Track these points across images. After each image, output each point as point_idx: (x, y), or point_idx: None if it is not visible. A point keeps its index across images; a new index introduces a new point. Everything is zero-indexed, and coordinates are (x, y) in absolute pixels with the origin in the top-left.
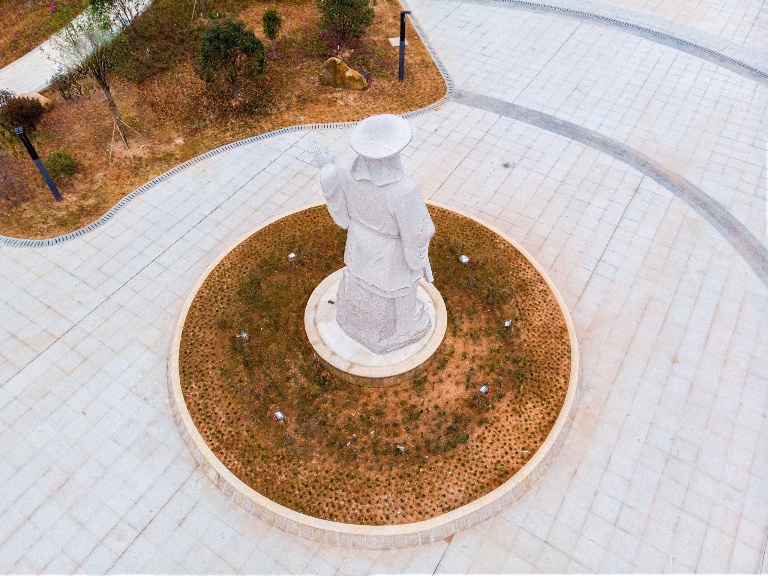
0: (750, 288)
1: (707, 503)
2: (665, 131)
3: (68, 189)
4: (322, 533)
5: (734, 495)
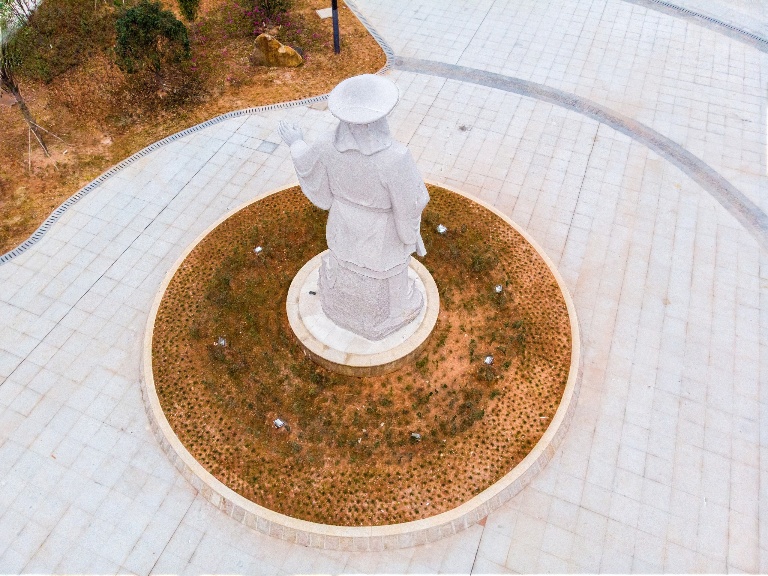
0: (721, 221)
1: (726, 439)
2: (610, 77)
3: None
4: (350, 541)
5: (749, 426)
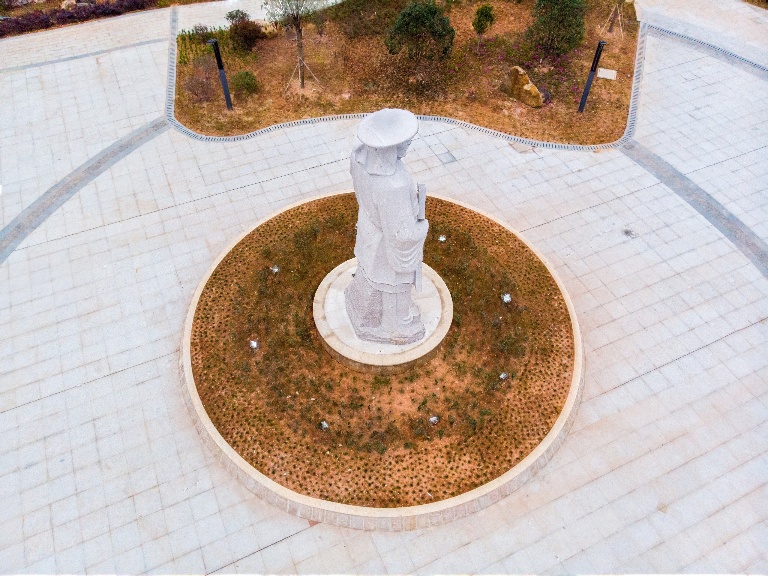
0: None
1: None
2: None
3: (242, 103)
4: (220, 452)
5: None
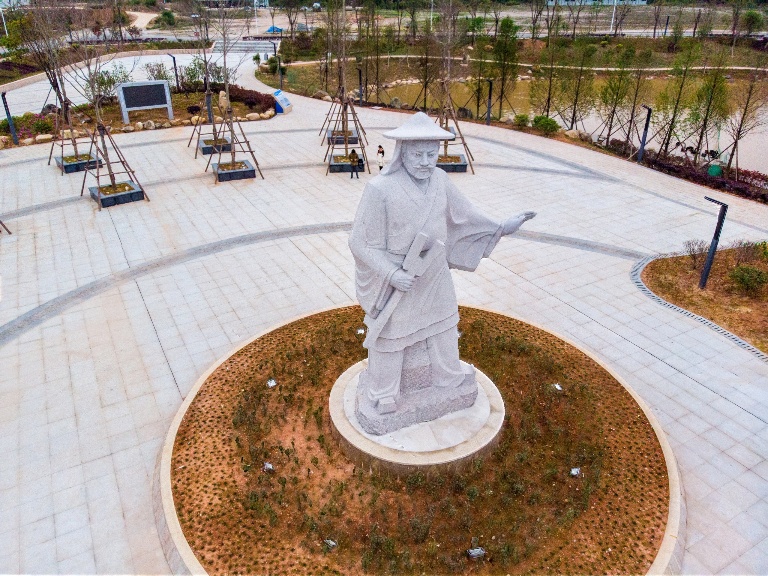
0: None
1: None
2: None
3: (722, 293)
4: None
5: None
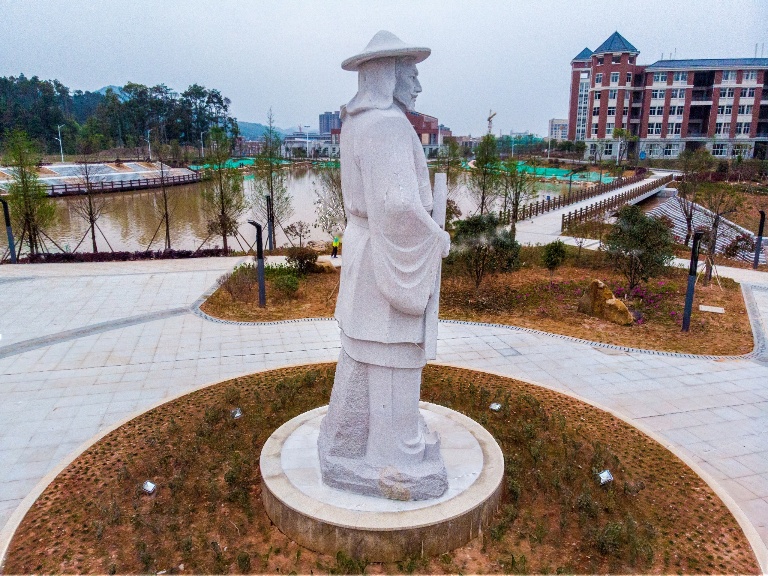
0: None
1: None
2: None
3: (277, 305)
4: None
5: None
